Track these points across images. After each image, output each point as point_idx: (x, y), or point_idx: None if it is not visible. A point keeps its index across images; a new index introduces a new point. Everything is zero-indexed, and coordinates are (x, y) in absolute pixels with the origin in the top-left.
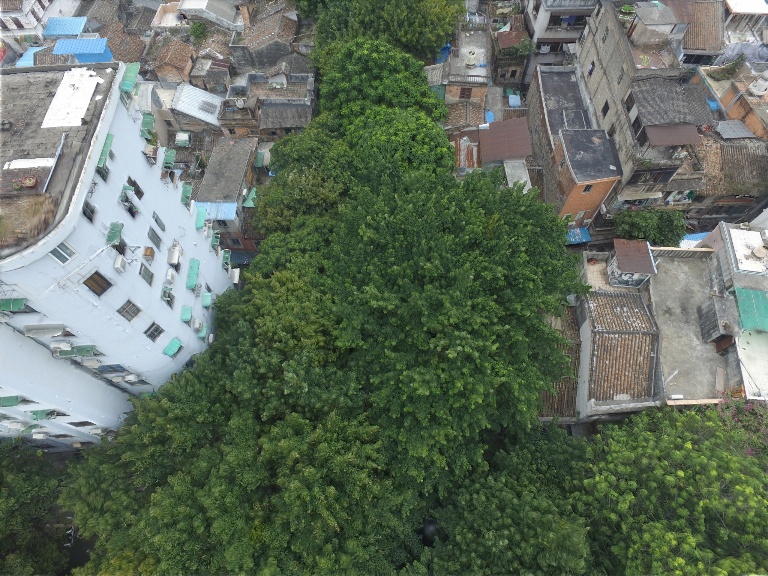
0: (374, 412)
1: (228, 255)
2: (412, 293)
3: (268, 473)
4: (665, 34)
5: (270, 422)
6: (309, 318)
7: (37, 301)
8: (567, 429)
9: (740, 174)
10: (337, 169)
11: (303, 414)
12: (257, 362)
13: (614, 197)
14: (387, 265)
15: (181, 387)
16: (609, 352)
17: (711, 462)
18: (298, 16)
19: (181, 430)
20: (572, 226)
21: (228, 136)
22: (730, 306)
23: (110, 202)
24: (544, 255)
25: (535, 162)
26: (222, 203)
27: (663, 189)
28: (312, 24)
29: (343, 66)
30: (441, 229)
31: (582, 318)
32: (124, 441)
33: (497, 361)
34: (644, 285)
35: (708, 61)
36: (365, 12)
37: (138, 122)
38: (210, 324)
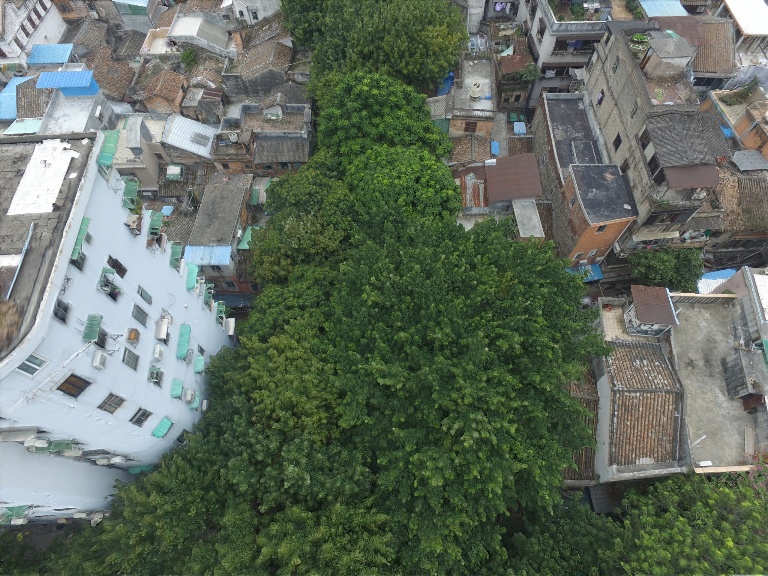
0: (382, 491)
1: (222, 308)
2: (421, 362)
3: (267, 571)
4: (681, 66)
5: (269, 511)
6: (310, 392)
7: (4, 412)
8: (585, 491)
9: (759, 208)
10: (337, 215)
11: (305, 503)
12: (254, 445)
13: (629, 237)
14: (393, 328)
15: (171, 475)
16: (630, 412)
17: (757, 567)
18: (293, 42)
19: (171, 526)
20: (583, 264)
21: (221, 171)
22: (758, 361)
23: (87, 292)
24: (561, 313)
25: (543, 195)
26: (216, 247)
27: (680, 228)
28: (308, 50)
29: (341, 101)
30: (450, 288)
31: (599, 371)
32: (109, 539)
33: (515, 438)
34: (664, 335)
35: (719, 84)
36: (364, 43)
37: (120, 192)
38: (203, 390)
